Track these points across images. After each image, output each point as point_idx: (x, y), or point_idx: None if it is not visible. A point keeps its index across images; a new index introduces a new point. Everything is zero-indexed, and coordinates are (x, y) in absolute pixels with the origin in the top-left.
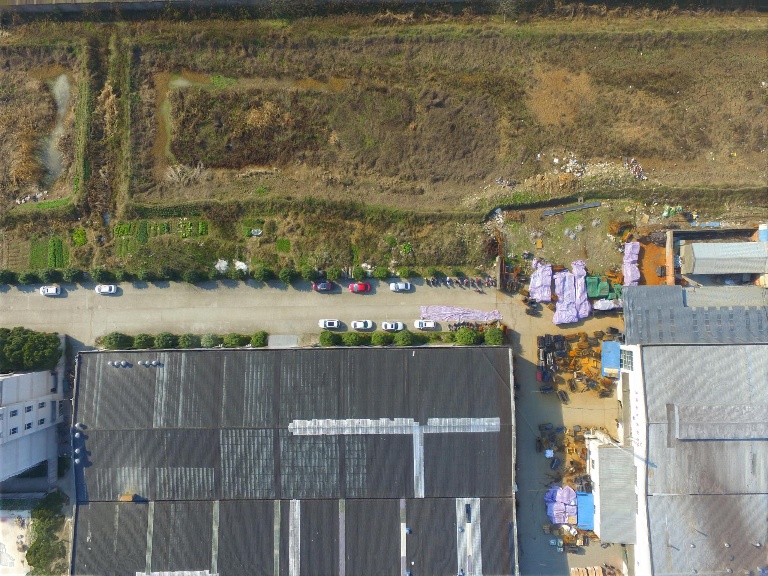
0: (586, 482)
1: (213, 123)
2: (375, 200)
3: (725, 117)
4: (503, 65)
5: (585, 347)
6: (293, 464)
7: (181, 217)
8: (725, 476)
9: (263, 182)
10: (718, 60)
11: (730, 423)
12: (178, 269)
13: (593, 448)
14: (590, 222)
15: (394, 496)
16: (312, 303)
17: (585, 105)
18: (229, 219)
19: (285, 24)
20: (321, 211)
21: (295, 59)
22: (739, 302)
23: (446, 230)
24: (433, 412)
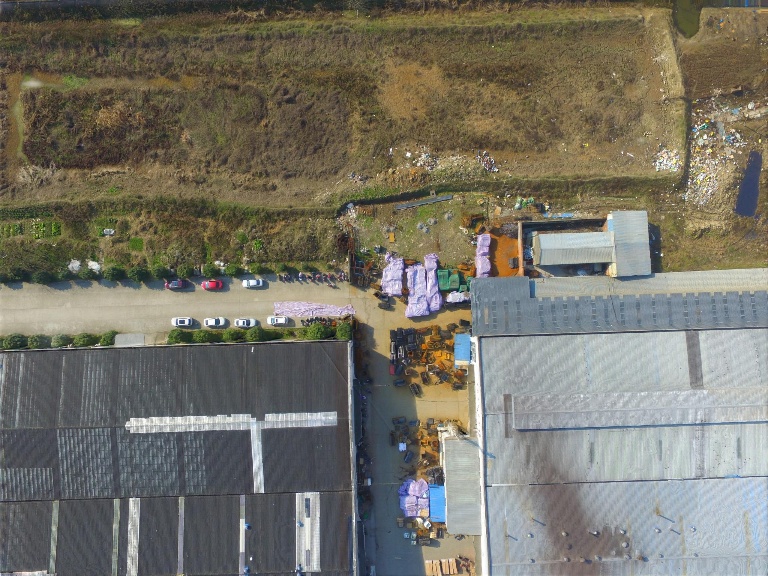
0: (438, 474)
1: (64, 123)
2: (227, 197)
3: (576, 108)
4: (355, 60)
5: (437, 340)
6: (131, 462)
7: (34, 218)
8: (564, 465)
9: (115, 181)
10: (570, 51)
11: (565, 412)
12: (31, 270)
13: (443, 440)
14: (443, 215)
15: (234, 492)
16: (165, 301)
17: (437, 99)
18: (81, 219)
19: (138, 23)
20: (172, 209)
21: (146, 58)
22: (586, 292)
23: (297, 226)
24: (270, 407)
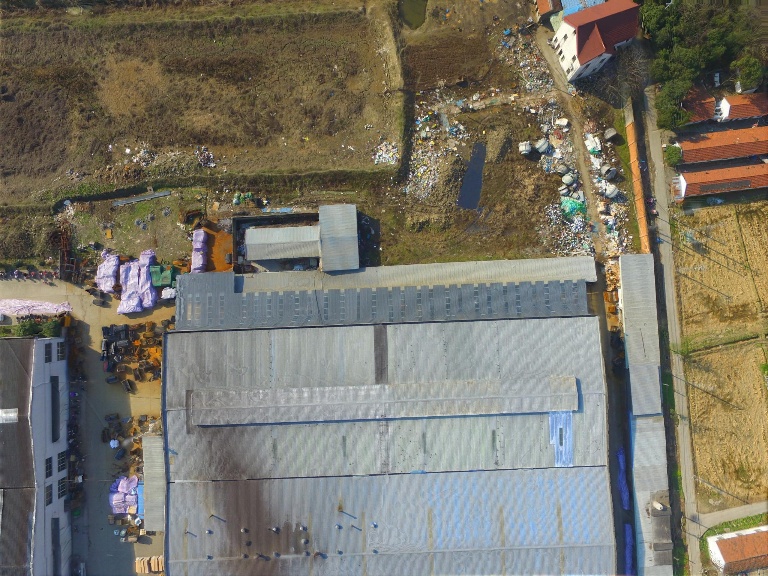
0: None
1: None
2: None
3: (296, 102)
4: (76, 57)
5: (149, 336)
6: None
7: None
8: (247, 461)
9: None
10: (292, 45)
11: (242, 408)
12: None
13: None
14: (160, 211)
15: None
16: None
17: (156, 94)
18: None
19: None
20: None
21: None
22: (291, 287)
23: (13, 223)
24: None
